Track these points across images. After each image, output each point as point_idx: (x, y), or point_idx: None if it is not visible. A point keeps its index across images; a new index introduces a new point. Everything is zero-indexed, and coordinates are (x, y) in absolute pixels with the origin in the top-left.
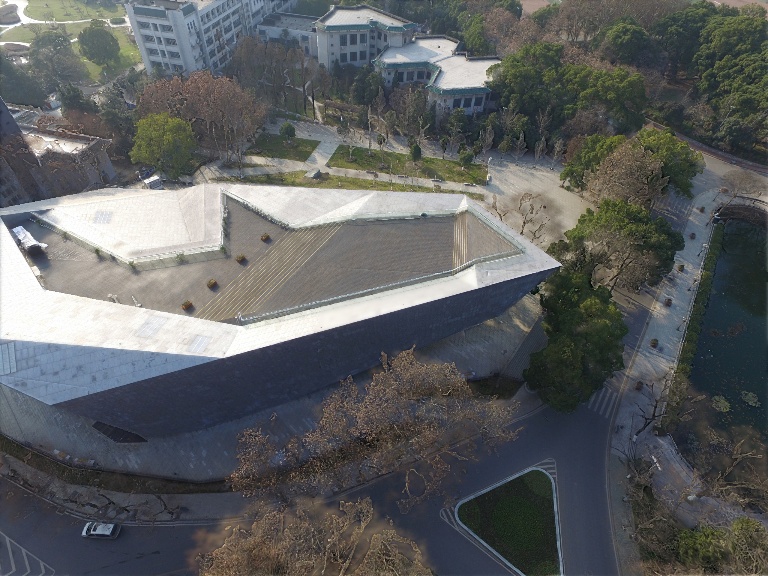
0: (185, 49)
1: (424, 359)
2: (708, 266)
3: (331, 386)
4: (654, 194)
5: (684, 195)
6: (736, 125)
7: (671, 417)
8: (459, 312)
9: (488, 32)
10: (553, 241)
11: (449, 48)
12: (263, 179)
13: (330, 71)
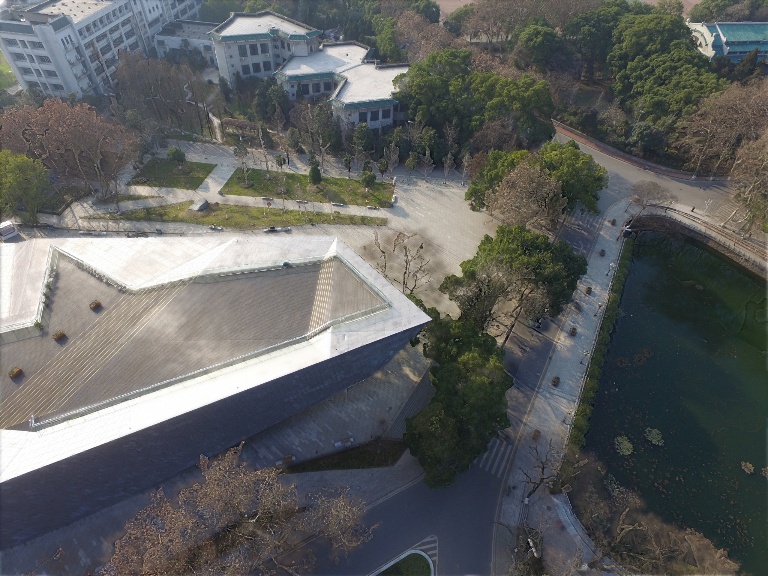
0: (62, 67)
1: (298, 426)
2: (615, 287)
3: (184, 471)
4: (555, 215)
5: (590, 211)
6: (647, 130)
7: (566, 471)
8: (318, 381)
9: (399, 37)
10: (456, 269)
11: (358, 56)
12: (142, 215)
13: (233, 84)
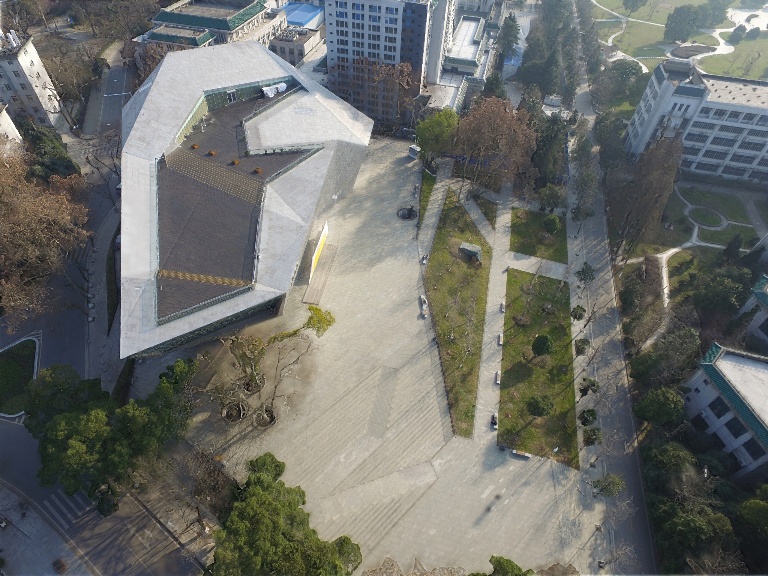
0: (652, 123)
1: None
2: None
3: None
4: None
5: None
6: None
7: None
8: None
9: None
10: (351, 521)
11: None
12: (453, 216)
13: None
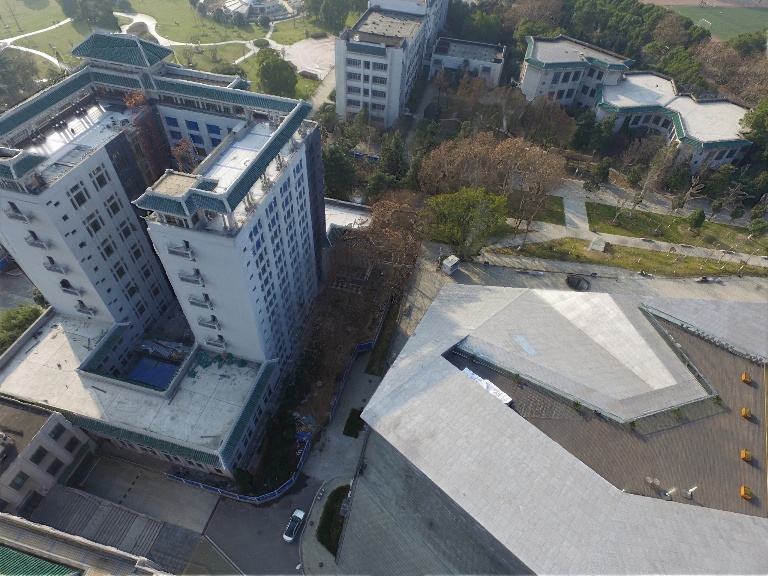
0: (392, 88)
1: None
2: None
3: None
4: None
5: None
6: None
7: None
8: None
9: (707, 70)
10: None
11: (666, 87)
12: (547, 252)
13: None
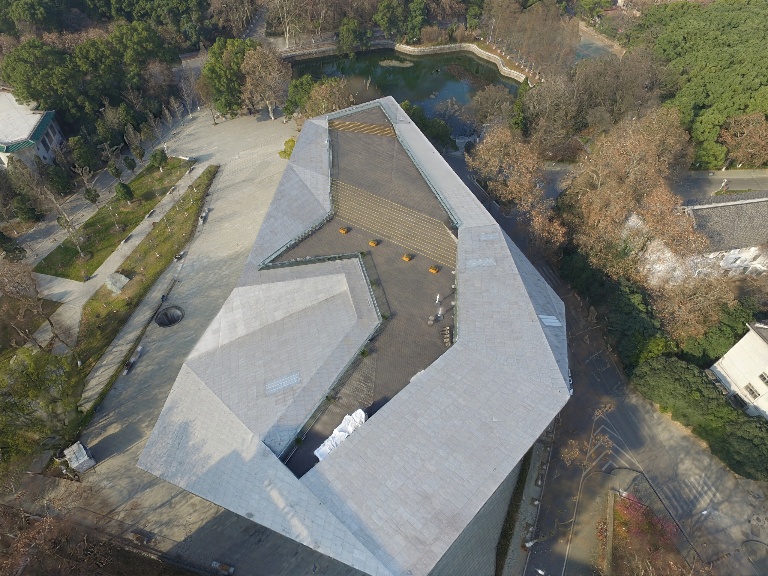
0: None
1: None
2: None
3: None
4: None
5: None
6: (196, 27)
7: None
8: None
9: None
10: None
11: None
12: (103, 334)
13: None
